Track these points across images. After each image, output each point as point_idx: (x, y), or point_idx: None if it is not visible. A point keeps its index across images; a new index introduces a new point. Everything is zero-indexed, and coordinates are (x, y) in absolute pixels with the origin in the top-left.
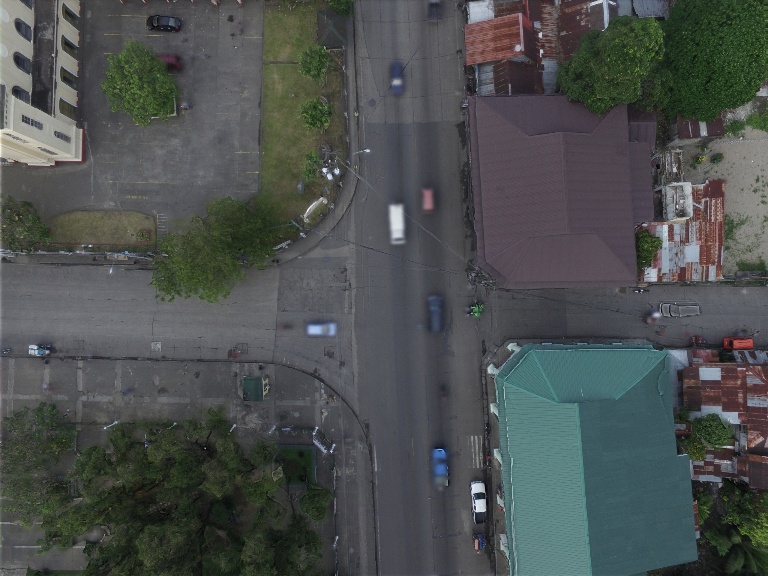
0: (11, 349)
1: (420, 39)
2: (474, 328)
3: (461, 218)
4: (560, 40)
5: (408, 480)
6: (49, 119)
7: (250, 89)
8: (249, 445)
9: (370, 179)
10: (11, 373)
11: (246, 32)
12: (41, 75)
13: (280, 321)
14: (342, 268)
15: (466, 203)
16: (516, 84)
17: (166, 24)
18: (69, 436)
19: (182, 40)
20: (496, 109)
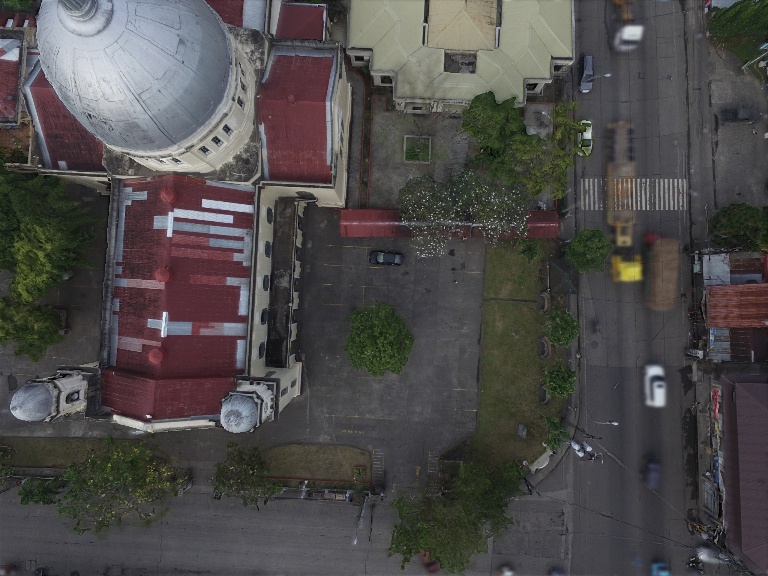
0: None
1: (645, 282)
2: None
3: (682, 466)
4: None
5: None
6: (290, 376)
7: (470, 325)
8: None
9: (590, 423)
10: None
11: (467, 267)
12: (276, 323)
13: (495, 564)
14: (559, 512)
15: (687, 450)
16: (757, 349)
17: (392, 261)
18: None
19: (403, 273)
20: (760, 400)
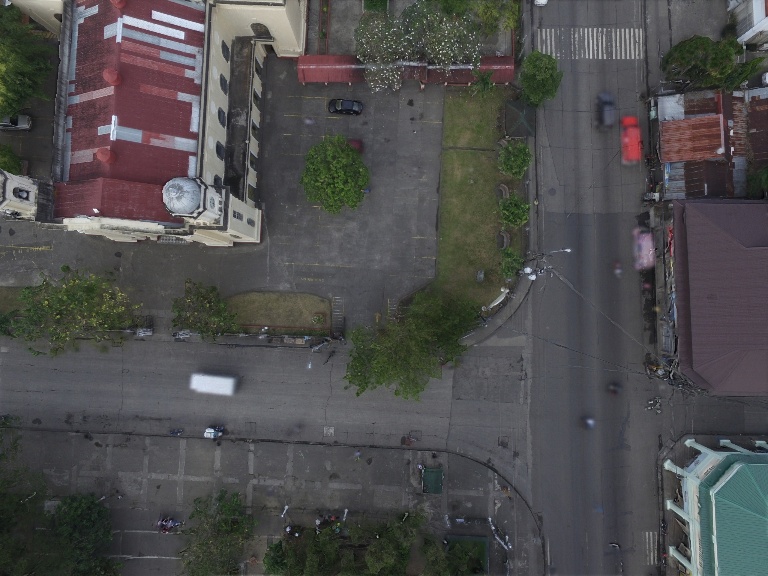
0: (183, 430)
1: (602, 129)
2: (651, 422)
3: (640, 311)
4: (749, 137)
5: (581, 575)
6: (245, 208)
7: (429, 174)
8: (421, 534)
9: None
10: (182, 454)
11: (426, 117)
12: (233, 161)
13: (454, 409)
14: (518, 357)
15: (645, 296)
16: (711, 184)
17: (350, 108)
18: (250, 525)
19: (362, 123)
20: (709, 217)
